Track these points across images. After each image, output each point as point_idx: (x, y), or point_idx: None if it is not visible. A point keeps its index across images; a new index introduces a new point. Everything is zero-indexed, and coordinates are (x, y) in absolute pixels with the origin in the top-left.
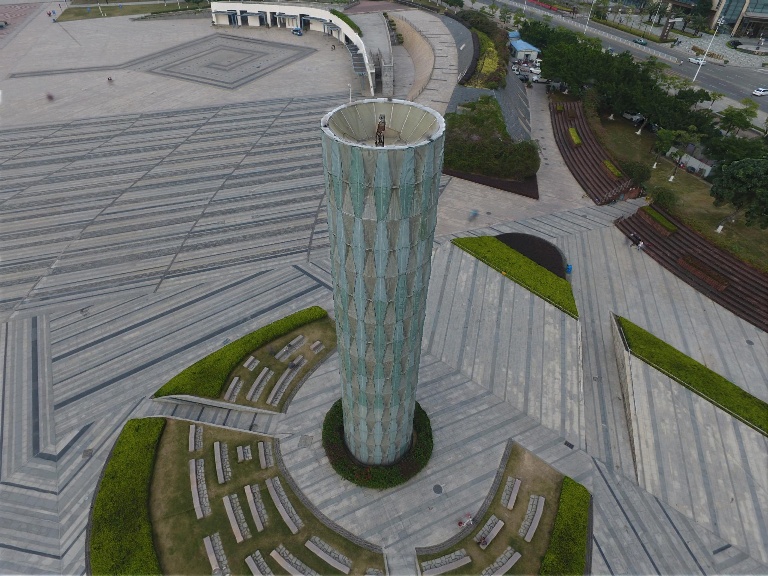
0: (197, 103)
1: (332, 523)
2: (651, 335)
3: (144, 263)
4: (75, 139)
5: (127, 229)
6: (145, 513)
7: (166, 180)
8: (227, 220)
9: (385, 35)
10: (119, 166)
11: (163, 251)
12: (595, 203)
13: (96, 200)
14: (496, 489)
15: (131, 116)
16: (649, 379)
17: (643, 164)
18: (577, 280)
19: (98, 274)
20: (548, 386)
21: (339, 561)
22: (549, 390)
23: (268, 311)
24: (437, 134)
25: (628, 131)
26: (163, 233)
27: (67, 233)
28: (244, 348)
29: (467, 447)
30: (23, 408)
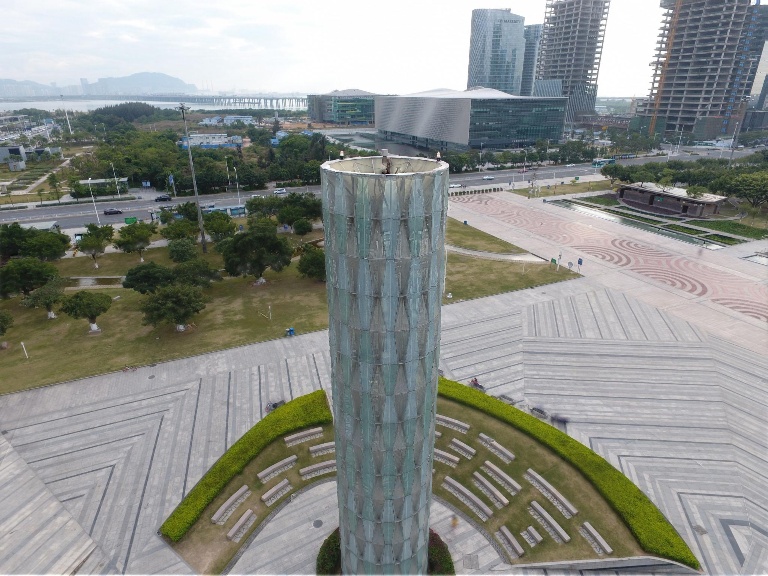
0: None
1: None
2: None
3: None
4: None
5: None
6: (573, 461)
7: None
8: None
9: None
10: None
11: None
12: None
13: None
14: (257, 529)
15: None
16: None
17: None
18: None
19: None
20: None
21: None
22: None
23: None
24: None
25: None
26: None
27: None
28: None
29: (274, 572)
30: None
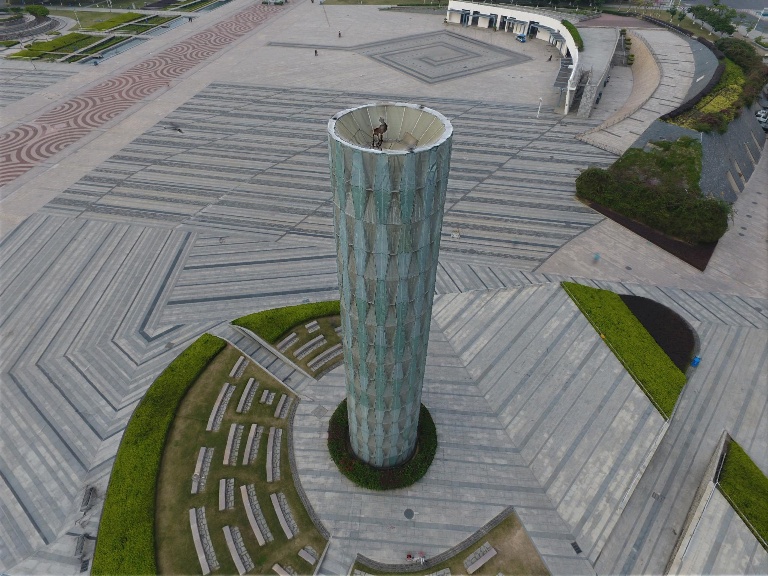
0: (393, 91)
1: (302, 491)
2: (767, 481)
3: (281, 215)
4: (286, 103)
5: (284, 184)
6: (174, 406)
7: None
8: None
9: (610, 53)
10: (305, 132)
11: (300, 210)
12: None
13: (275, 155)
14: (467, 546)
15: (335, 92)
16: (726, 529)
17: None
18: (700, 378)
19: (246, 214)
20: (587, 475)
21: (289, 525)
22: (586, 480)
23: None
24: (424, 147)
25: None
26: (307, 195)
27: (242, 176)
28: (313, 311)
29: (461, 491)
30: (150, 295)
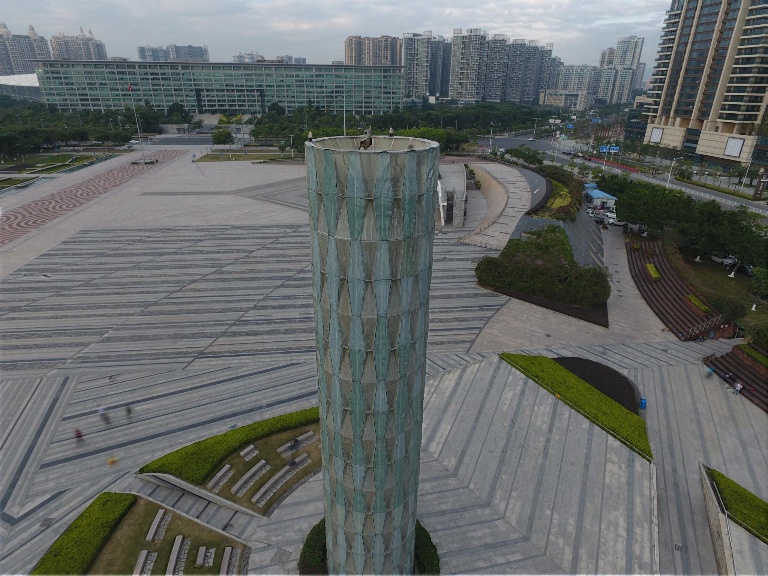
0: (282, 221)
1: None
2: (760, 500)
3: (185, 342)
4: (171, 240)
5: (182, 312)
6: None
7: (233, 276)
8: (275, 314)
9: (462, 179)
10: (198, 262)
11: (206, 334)
12: (678, 338)
13: (167, 286)
14: None
15: (224, 226)
16: (760, 560)
17: (735, 299)
18: (654, 418)
19: (140, 347)
20: (607, 544)
21: None
22: (609, 550)
23: (286, 402)
24: (422, 148)
25: (718, 273)
26: (213, 318)
27: (130, 310)
28: (247, 434)
29: None
30: (12, 462)
